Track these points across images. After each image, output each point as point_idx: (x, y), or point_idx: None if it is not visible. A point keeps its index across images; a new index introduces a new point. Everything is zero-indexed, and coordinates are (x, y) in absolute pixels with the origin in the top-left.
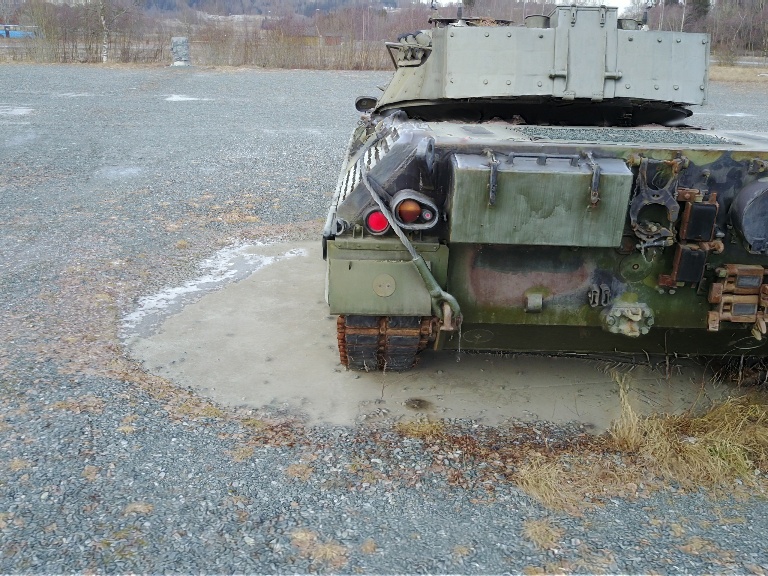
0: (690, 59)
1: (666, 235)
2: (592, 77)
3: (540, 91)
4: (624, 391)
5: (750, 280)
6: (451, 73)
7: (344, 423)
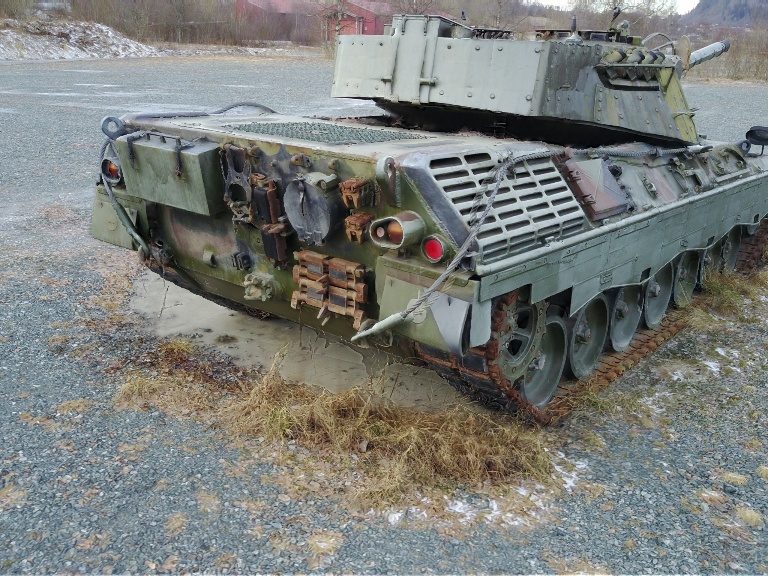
0: (514, 68)
1: (246, 212)
2: (413, 82)
3: (377, 94)
4: (280, 354)
5: (315, 267)
6: (336, 76)
7: (163, 335)
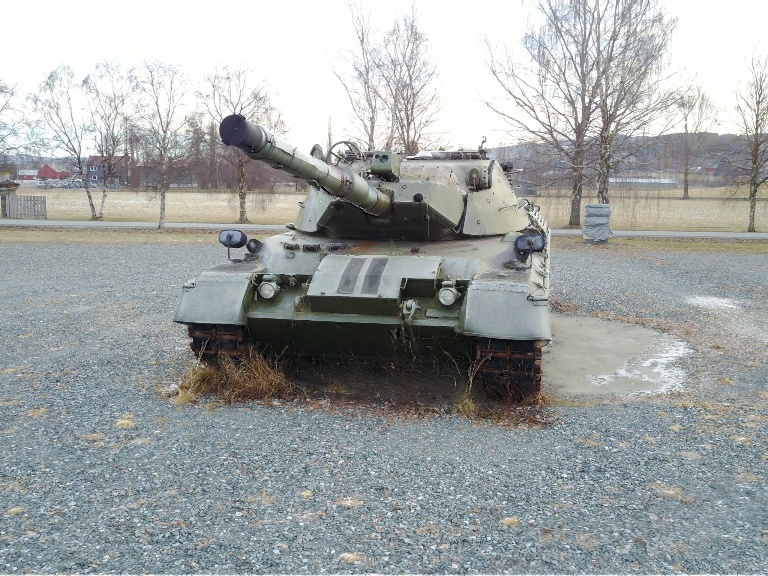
0: None
1: None
2: None
3: None
4: None
5: None
6: None
7: None
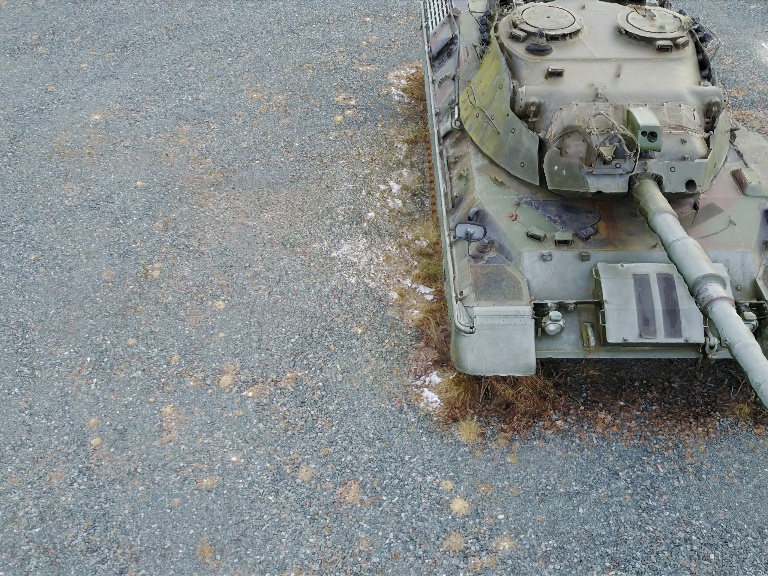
0: None
1: None
2: None
3: None
4: None
5: None
6: None
7: None
